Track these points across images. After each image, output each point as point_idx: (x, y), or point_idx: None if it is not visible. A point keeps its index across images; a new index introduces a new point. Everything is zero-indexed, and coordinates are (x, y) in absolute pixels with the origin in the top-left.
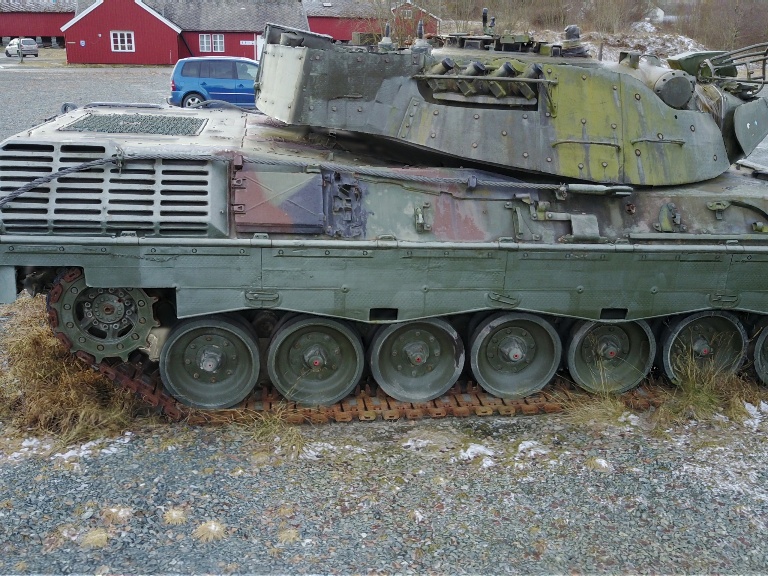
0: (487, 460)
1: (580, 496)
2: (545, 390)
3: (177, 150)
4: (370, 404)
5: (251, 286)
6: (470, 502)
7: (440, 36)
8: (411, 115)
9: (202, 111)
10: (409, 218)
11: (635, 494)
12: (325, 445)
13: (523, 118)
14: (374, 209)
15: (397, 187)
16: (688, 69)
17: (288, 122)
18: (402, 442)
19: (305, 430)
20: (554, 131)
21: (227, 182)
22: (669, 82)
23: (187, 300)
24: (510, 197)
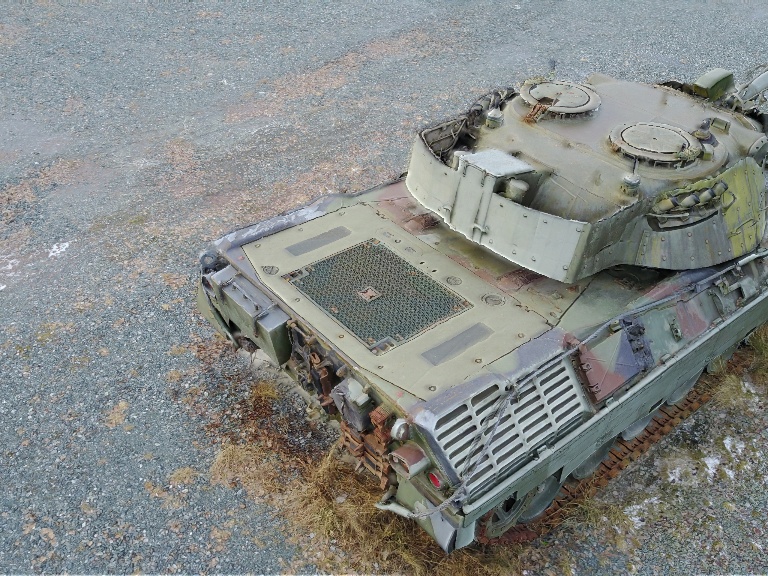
0: (729, 472)
1: None
2: (695, 387)
3: (540, 359)
4: (616, 452)
5: (601, 436)
6: (766, 518)
7: (557, 112)
8: (645, 245)
9: (334, 217)
10: (669, 333)
11: None
12: (635, 508)
13: (714, 224)
14: (651, 337)
15: (655, 311)
16: (711, 94)
17: (566, 282)
18: (667, 478)
19: (603, 498)
20: (727, 225)
21: (572, 367)
22: (761, 149)
23: (567, 469)
24: (709, 285)
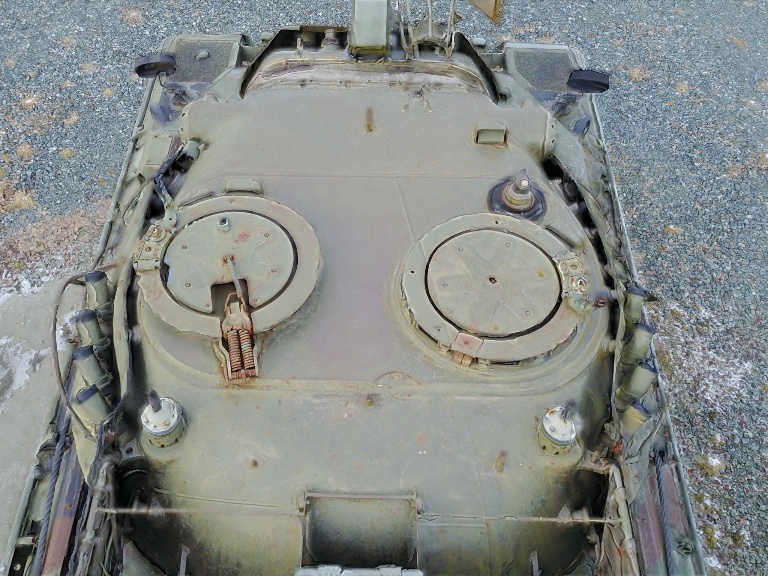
0: (712, 562)
1: (767, 501)
2: None
3: None
4: None
5: None
6: None
7: None
8: None
9: None
10: None
11: (760, 456)
12: None
13: None
14: None
15: None
16: None
17: None
18: None
19: None
20: None
21: None
22: None
23: None
24: None
